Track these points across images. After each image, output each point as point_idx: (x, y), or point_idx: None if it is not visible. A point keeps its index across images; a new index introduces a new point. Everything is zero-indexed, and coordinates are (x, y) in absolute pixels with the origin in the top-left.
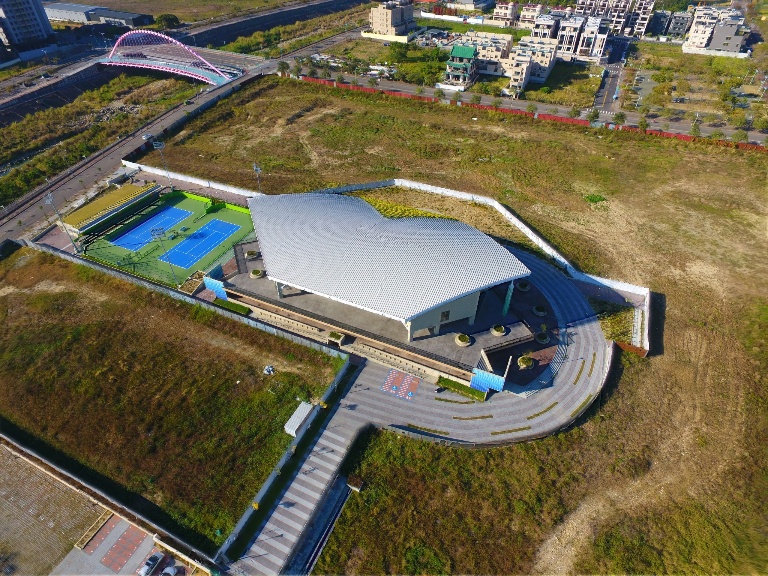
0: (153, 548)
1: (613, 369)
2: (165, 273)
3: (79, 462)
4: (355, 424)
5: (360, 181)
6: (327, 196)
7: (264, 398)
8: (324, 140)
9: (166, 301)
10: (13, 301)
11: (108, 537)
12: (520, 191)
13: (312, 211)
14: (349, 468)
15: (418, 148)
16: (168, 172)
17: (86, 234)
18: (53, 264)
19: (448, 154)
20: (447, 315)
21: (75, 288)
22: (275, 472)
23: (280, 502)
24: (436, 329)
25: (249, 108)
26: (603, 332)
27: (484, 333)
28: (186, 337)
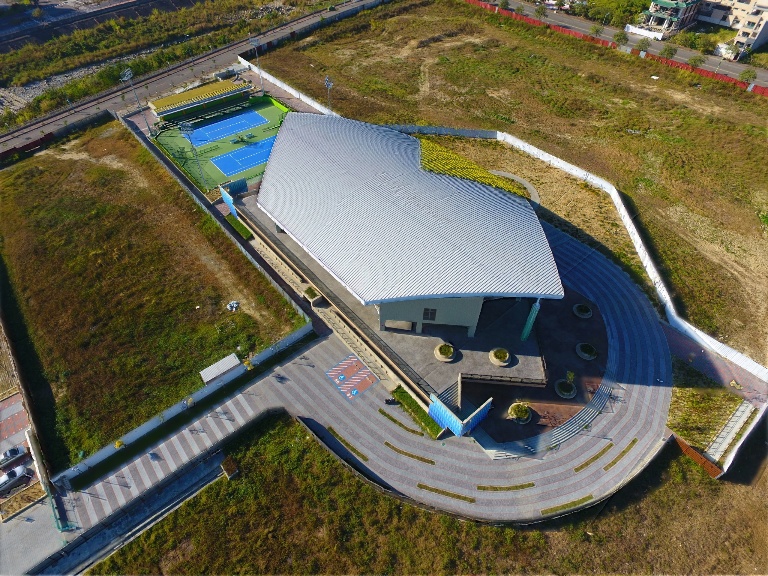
0: (25, 440)
1: (650, 474)
2: (206, 175)
3: (27, 331)
4: (274, 401)
5: (458, 125)
6: (377, 129)
7: (208, 334)
8: (447, 71)
9: (188, 203)
10: (79, 166)
11: (3, 411)
12: (663, 184)
13: (343, 141)
14: (234, 448)
15: (554, 101)
16: (269, 75)
17: (167, 120)
18: (127, 141)
19: (589, 115)
20: (433, 314)
21: (129, 168)
22: (159, 418)
23: (151, 451)
24: (417, 326)
25: (389, 23)
26: (668, 415)
27: (479, 353)
28: (183, 245)
